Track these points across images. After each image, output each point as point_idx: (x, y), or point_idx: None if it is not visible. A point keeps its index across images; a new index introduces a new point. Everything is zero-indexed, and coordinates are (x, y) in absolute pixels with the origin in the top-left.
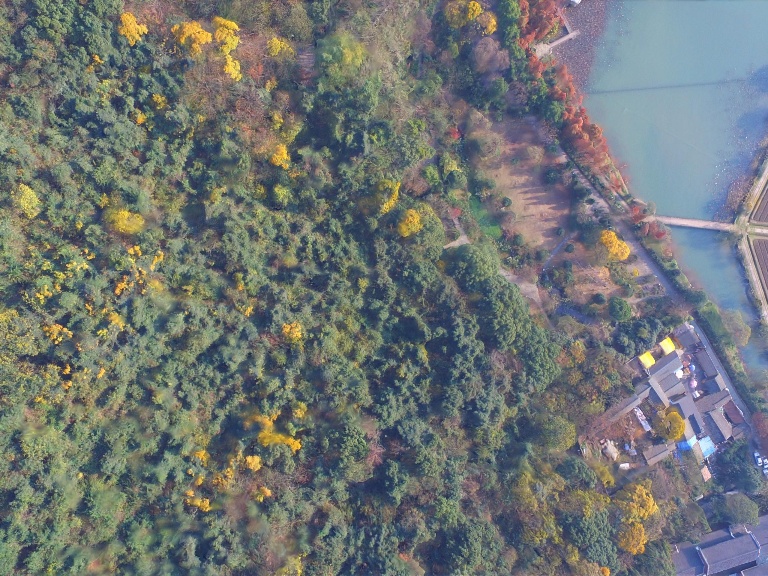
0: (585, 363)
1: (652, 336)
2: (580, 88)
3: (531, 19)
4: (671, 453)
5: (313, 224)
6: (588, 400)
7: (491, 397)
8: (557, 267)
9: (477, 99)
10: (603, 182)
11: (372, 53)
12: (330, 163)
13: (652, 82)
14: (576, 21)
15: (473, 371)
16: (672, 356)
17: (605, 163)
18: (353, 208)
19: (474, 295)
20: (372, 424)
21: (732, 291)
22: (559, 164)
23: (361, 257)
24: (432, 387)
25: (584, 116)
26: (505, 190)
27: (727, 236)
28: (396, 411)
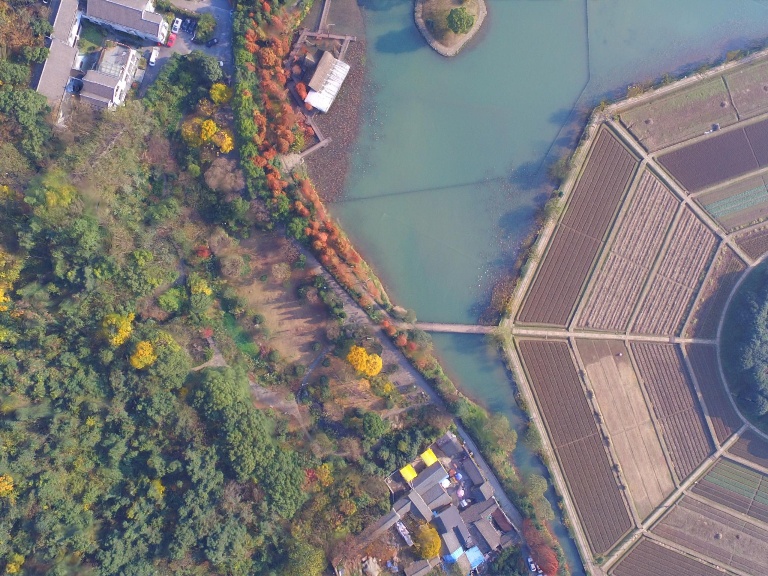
0: (332, 486)
1: (412, 449)
2: (335, 196)
3: (270, 134)
4: (438, 566)
5: (45, 360)
6: (332, 526)
7: (226, 532)
8: (315, 382)
9: (224, 216)
10: (361, 292)
11: (86, 189)
12: (57, 299)
13: (410, 185)
14: (328, 128)
15: (206, 507)
16: (435, 467)
17: (363, 272)
18: (89, 340)
19: (214, 424)
20: (87, 575)
21: (500, 394)
22: (314, 276)
23: (101, 389)
24: (166, 524)
25: (331, 229)
26: (258, 306)
27: (490, 340)
28: (122, 555)
